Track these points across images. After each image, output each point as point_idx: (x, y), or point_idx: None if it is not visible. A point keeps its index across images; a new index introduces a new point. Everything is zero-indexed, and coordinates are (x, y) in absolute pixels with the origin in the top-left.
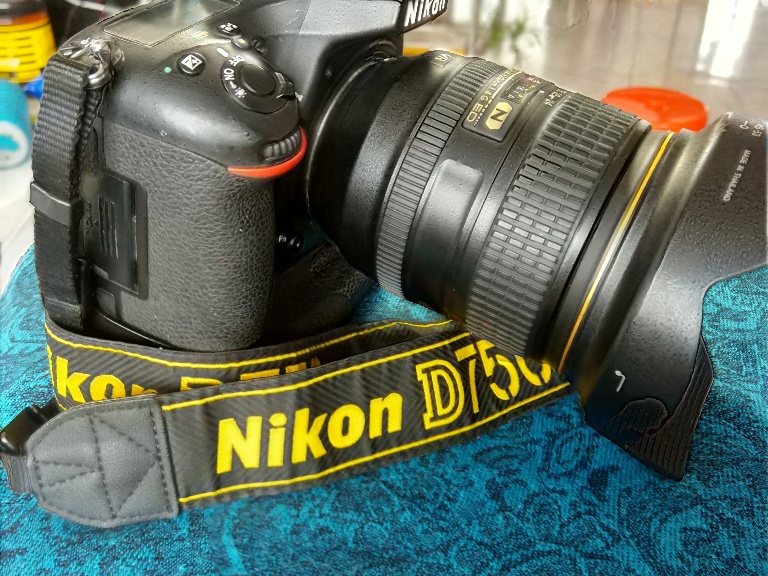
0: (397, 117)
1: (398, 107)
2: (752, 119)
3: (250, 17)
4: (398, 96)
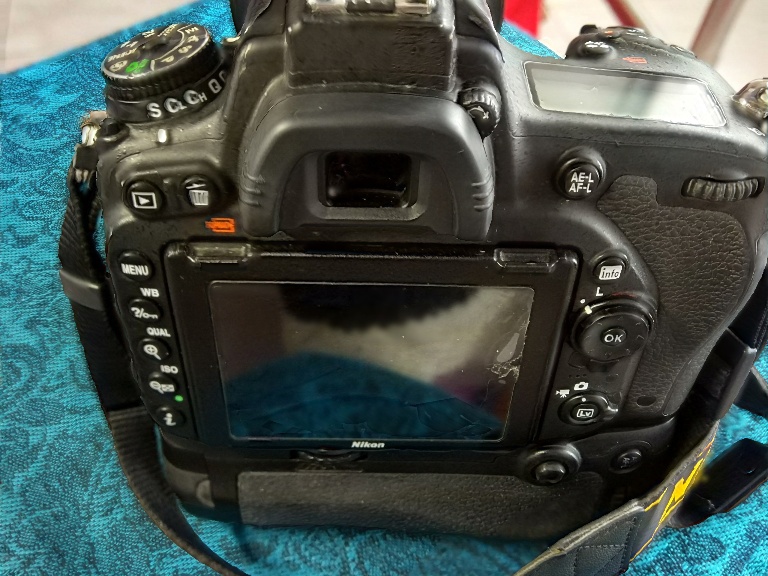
0: None
1: None
2: None
3: None
4: None
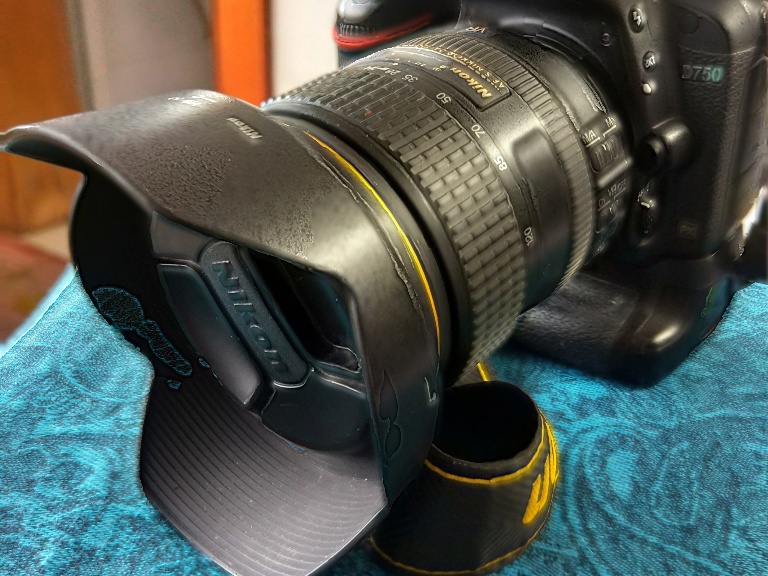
0: None
1: None
2: (222, 108)
3: None
4: None
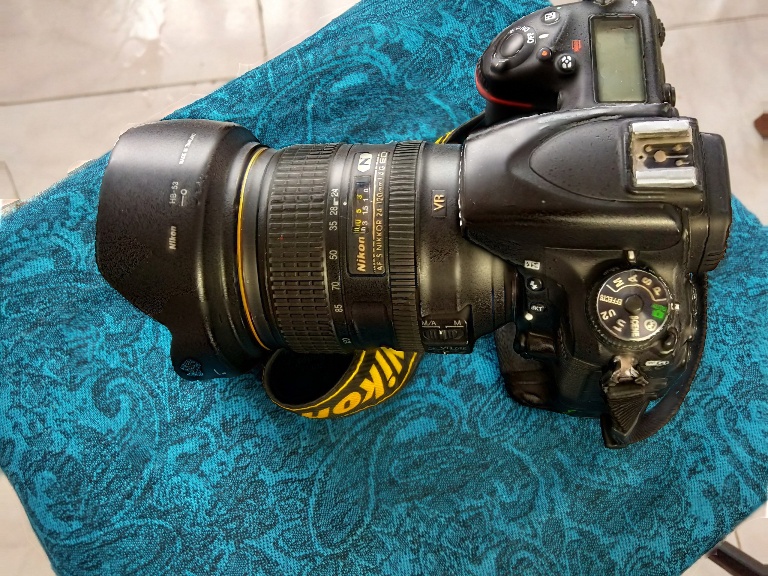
0: (442, 149)
1: (445, 152)
2: (178, 215)
3: (577, 98)
4: (450, 156)
